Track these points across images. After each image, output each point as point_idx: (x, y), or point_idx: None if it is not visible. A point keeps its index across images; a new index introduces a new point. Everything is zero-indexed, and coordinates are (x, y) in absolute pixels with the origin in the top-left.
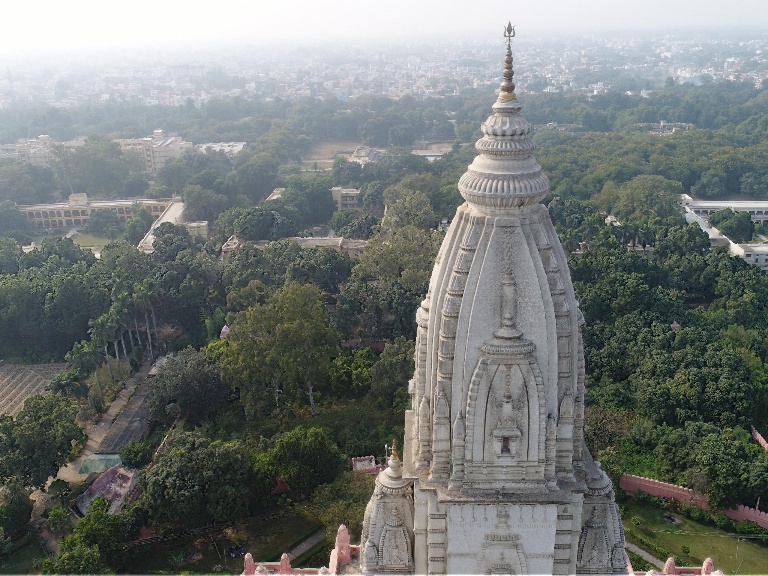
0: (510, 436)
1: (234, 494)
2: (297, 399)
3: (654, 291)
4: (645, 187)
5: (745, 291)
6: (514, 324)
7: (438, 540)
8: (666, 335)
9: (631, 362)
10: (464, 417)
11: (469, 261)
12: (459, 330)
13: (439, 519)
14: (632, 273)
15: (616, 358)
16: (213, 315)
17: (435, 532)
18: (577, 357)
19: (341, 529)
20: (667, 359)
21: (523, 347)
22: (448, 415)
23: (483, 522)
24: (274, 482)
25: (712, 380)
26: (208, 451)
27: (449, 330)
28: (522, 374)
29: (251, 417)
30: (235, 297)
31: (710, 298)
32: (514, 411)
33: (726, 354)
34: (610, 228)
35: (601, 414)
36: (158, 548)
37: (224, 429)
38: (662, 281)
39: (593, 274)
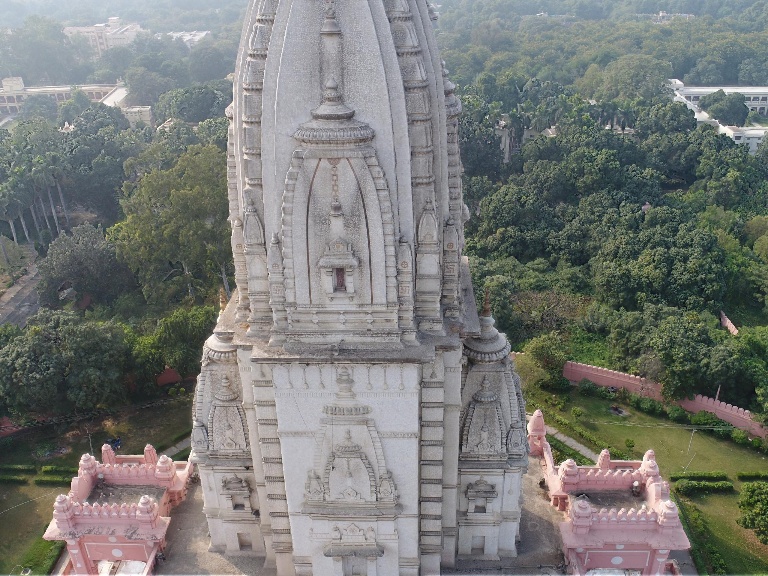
0: (342, 266)
1: (99, 378)
2: (214, 284)
3: (626, 169)
4: (631, 67)
5: (729, 170)
6: (341, 97)
7: (268, 415)
8: (634, 215)
9: (592, 244)
10: (281, 241)
11: (275, 2)
12: (264, 109)
13: (266, 387)
14: (603, 149)
15: (576, 240)
16: (130, 195)
17: (263, 405)
18: (446, 159)
19: None
20: (632, 239)
21: (352, 131)
22: (262, 241)
23: (319, 390)
24: (157, 367)
25: (680, 261)
26: (69, 329)
27: (251, 111)
28: (354, 173)
29: (152, 301)
30: (132, 163)
31: (691, 183)
32: (347, 230)
33: (699, 234)
34: (586, 107)
35: (554, 300)
36: (23, 441)
37: (122, 314)
38: (639, 163)
39: (561, 154)
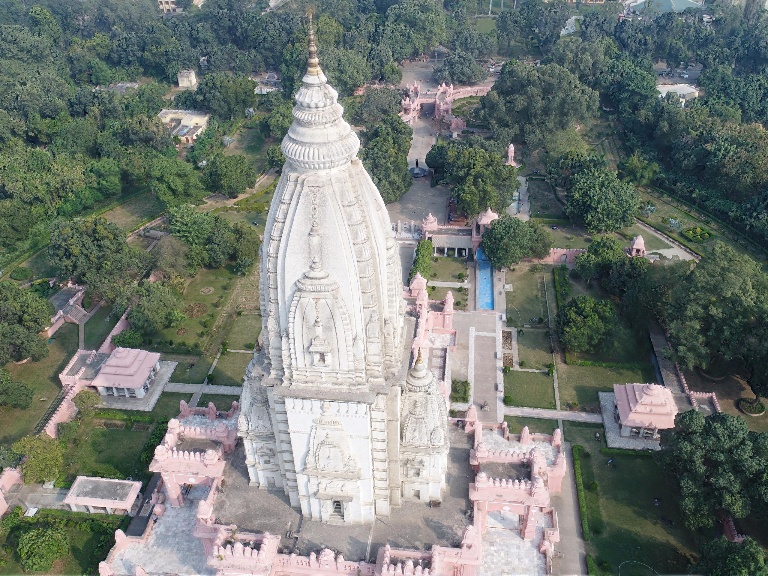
0: None
1: None
2: None
3: None
4: None
5: None
6: None
7: None
8: None
9: None
10: None
11: None
12: None
13: None
14: None
15: None
16: None
17: None
18: None
19: (471, 525)
20: None
21: None
22: None
23: None
24: None
25: None
26: None
27: None
28: None
29: None
30: None
31: None
32: None
33: None
34: None
35: None
36: None
37: None
38: None
39: None
